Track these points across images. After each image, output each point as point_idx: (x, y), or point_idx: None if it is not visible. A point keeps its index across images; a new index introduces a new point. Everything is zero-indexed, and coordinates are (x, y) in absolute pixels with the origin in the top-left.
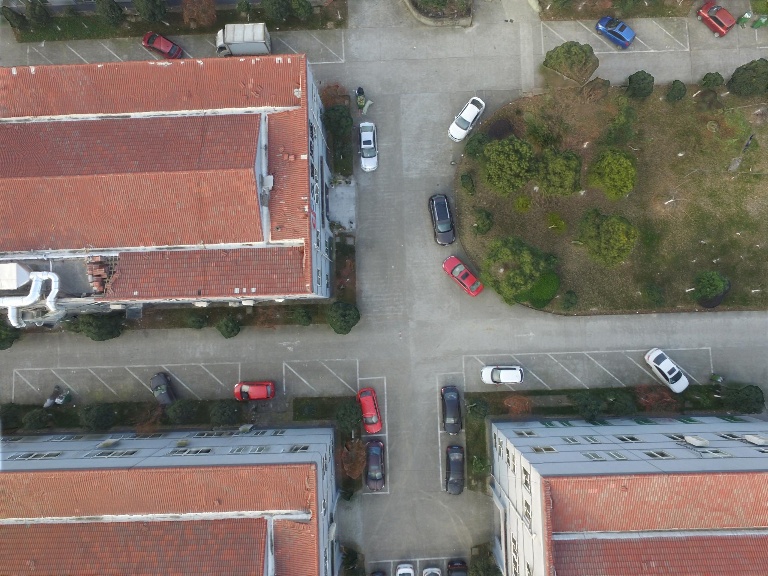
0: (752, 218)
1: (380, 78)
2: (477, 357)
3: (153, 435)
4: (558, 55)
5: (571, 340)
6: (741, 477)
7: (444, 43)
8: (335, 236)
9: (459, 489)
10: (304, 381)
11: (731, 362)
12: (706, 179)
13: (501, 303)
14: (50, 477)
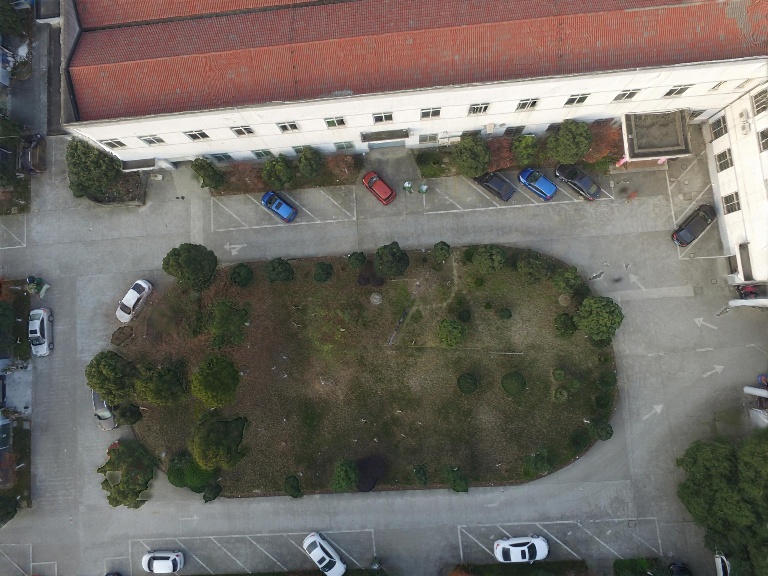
0: (414, 394)
1: (58, 261)
2: (143, 541)
3: None
4: None
5: (234, 523)
6: None
7: (119, 223)
8: (12, 421)
9: None
10: None
11: (394, 545)
12: (368, 354)
13: (167, 486)
14: None
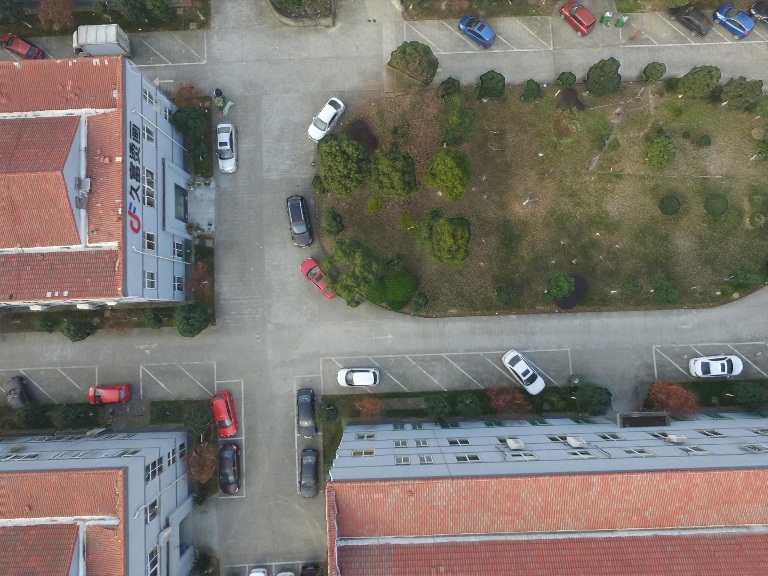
0: (612, 218)
1: (242, 79)
2: (335, 359)
3: None
4: (396, 55)
5: (429, 342)
6: (526, 481)
7: (307, 43)
8: (194, 238)
9: (313, 493)
10: (161, 384)
11: (590, 363)
12: (566, 179)
13: (360, 305)
14: None
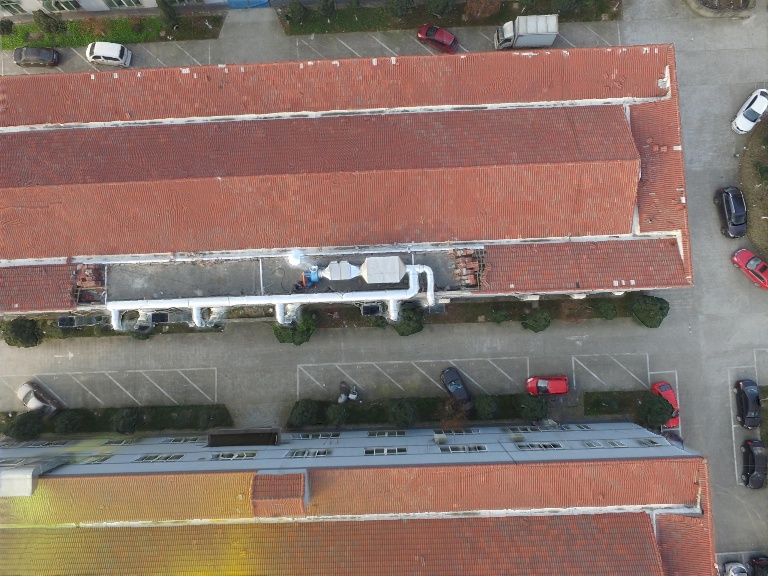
0: None
1: None
2: None
3: (472, 430)
4: None
5: None
6: None
7: (722, 34)
8: None
9: (760, 483)
10: (594, 375)
11: None
12: None
13: None
14: (439, 472)
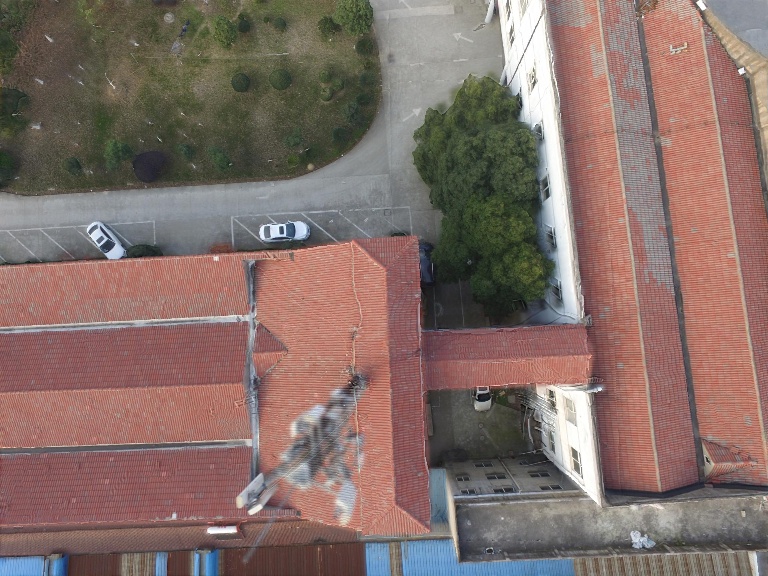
0: (198, 99)
1: None
2: None
3: None
4: None
5: (29, 218)
6: None
7: None
8: None
9: None
10: None
11: (172, 234)
12: (158, 65)
13: None
14: None
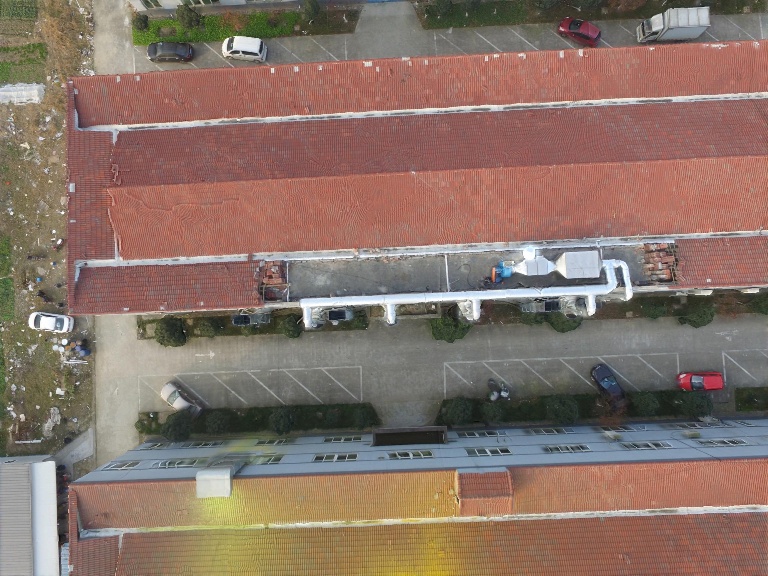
0: None
1: None
2: None
3: None
4: None
5: None
6: None
7: None
8: None
9: None
10: (745, 371)
11: None
12: None
13: None
14: (642, 469)
